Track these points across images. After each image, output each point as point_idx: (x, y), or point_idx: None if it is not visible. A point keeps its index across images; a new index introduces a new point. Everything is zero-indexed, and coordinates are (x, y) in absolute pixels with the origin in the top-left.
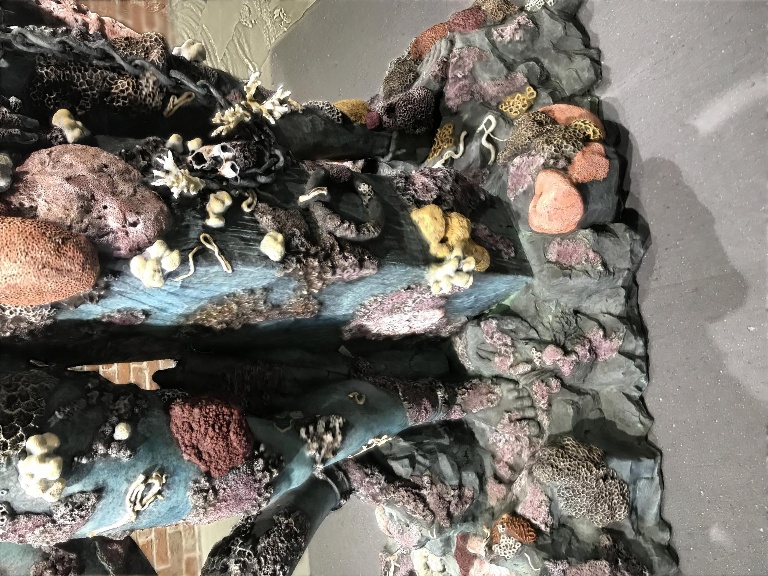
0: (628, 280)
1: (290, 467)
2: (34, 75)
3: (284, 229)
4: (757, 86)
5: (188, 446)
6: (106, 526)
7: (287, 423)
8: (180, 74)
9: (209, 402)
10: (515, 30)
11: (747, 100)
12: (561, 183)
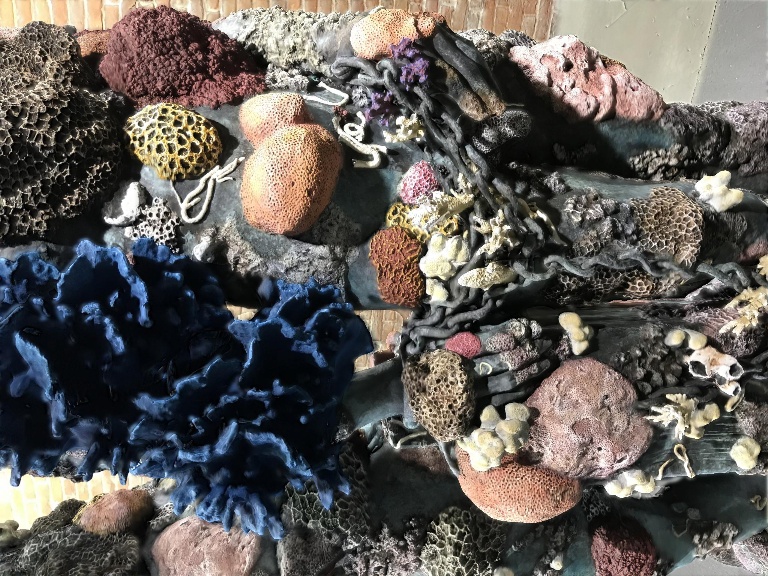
0: None
1: (676, 565)
2: (555, 283)
3: (764, 434)
4: None
5: (603, 569)
6: None
7: (683, 524)
8: (709, 269)
9: (630, 544)
10: None
11: None
12: None
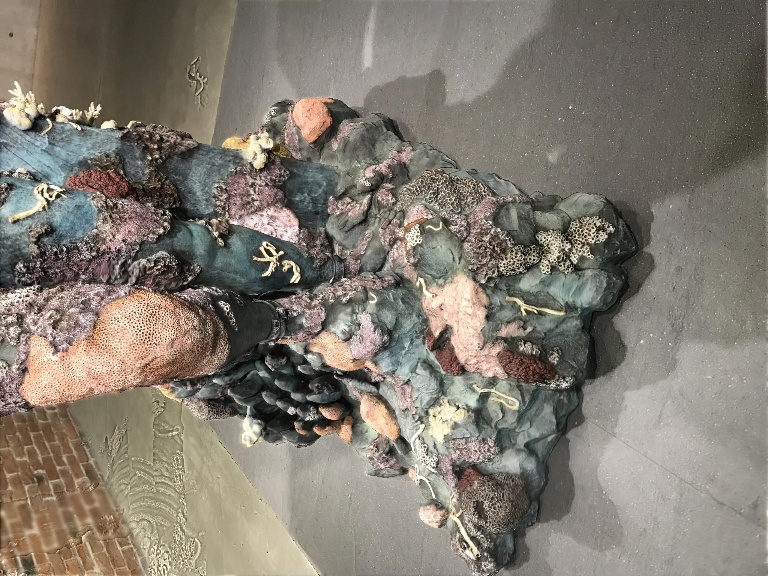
0: (390, 129)
1: None
2: None
3: None
4: (370, 27)
5: None
6: (24, 212)
7: None
8: None
9: None
10: (262, 130)
11: (372, 34)
12: (301, 100)
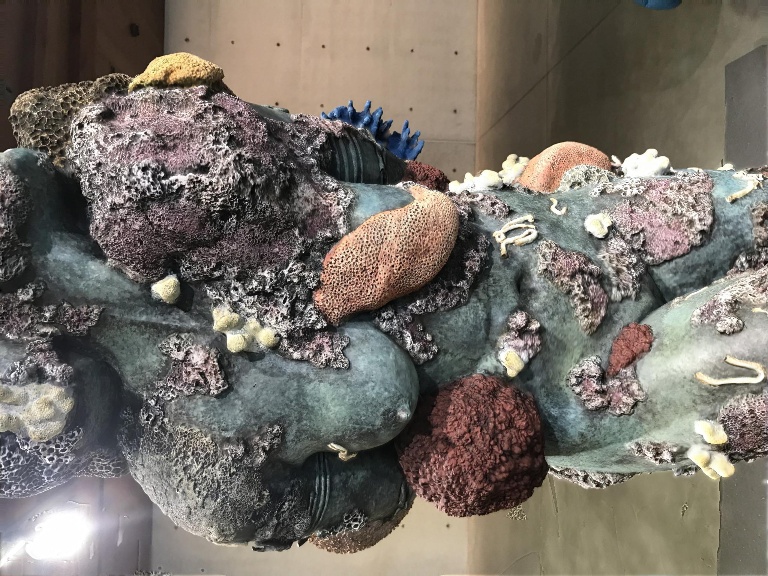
0: None
1: None
2: None
3: None
4: None
5: None
6: (738, 191)
7: None
8: None
9: None
10: None
11: None
12: None
